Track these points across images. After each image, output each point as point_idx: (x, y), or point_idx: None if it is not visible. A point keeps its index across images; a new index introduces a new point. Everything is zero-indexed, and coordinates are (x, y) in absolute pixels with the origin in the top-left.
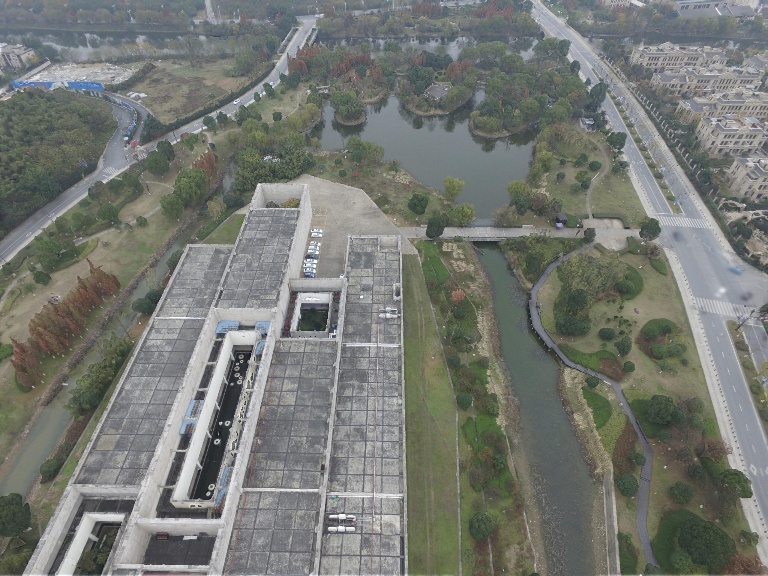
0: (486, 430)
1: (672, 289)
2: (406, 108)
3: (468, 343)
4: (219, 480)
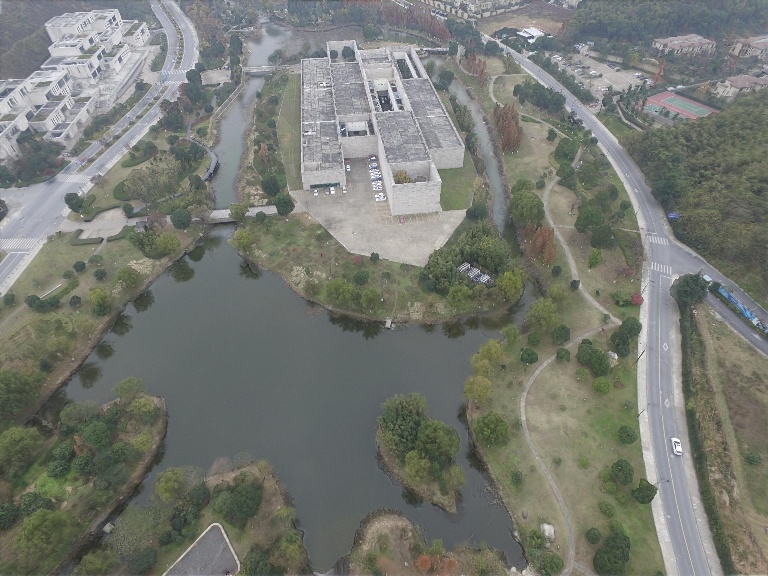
0: None
1: None
2: (289, 496)
3: None
4: None
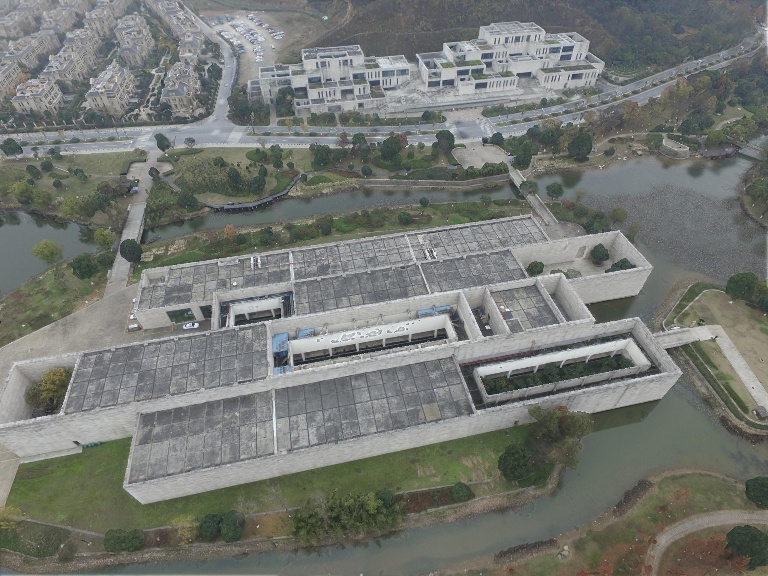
0: (344, 223)
1: (217, 150)
2: None
3: (272, 235)
4: (433, 316)
